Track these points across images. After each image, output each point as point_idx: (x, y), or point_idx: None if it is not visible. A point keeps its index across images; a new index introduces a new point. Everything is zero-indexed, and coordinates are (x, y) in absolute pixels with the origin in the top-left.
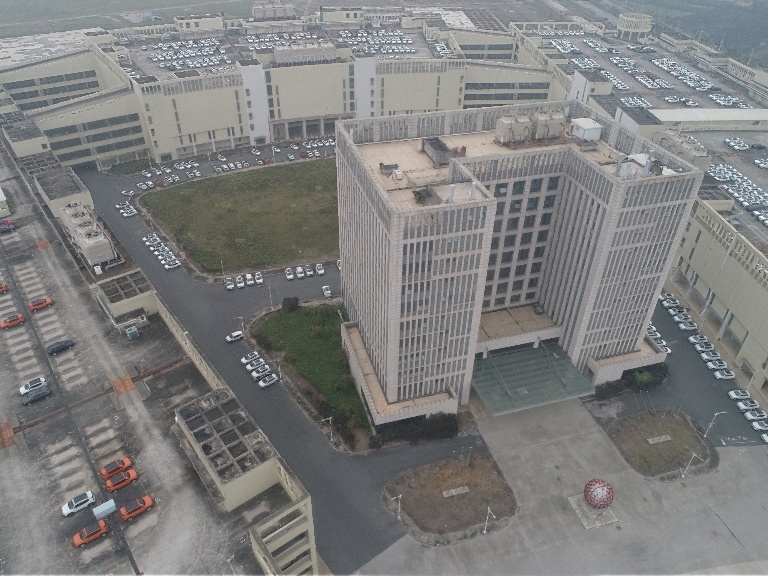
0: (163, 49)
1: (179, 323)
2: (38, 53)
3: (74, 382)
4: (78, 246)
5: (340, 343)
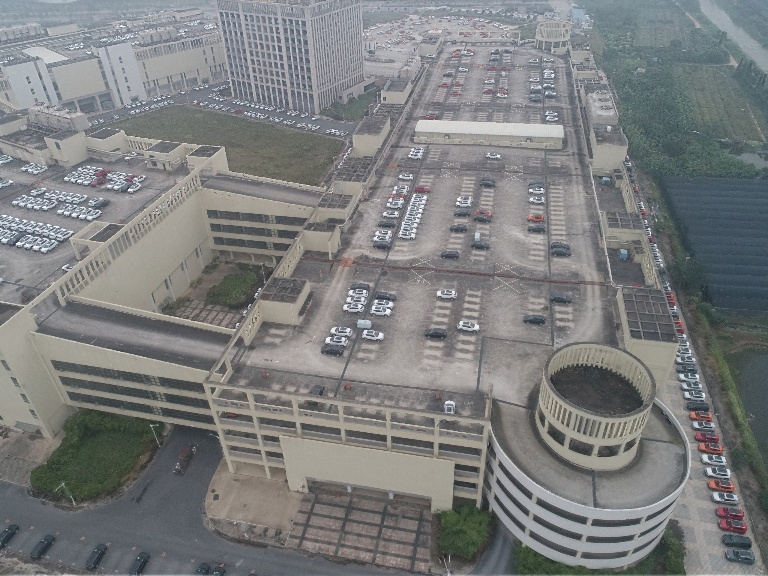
0: None
1: None
2: None
3: None
4: None
5: None
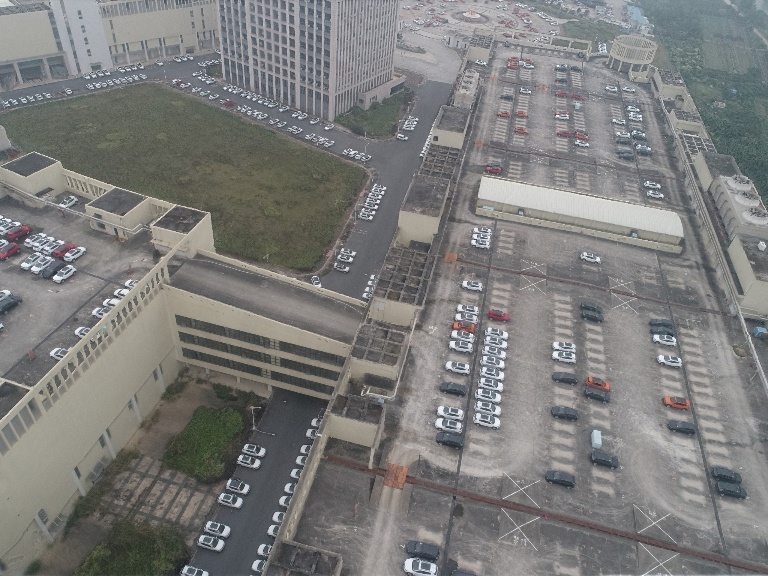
0: None
1: (463, 61)
2: None
3: (510, 89)
4: None
5: (365, 111)
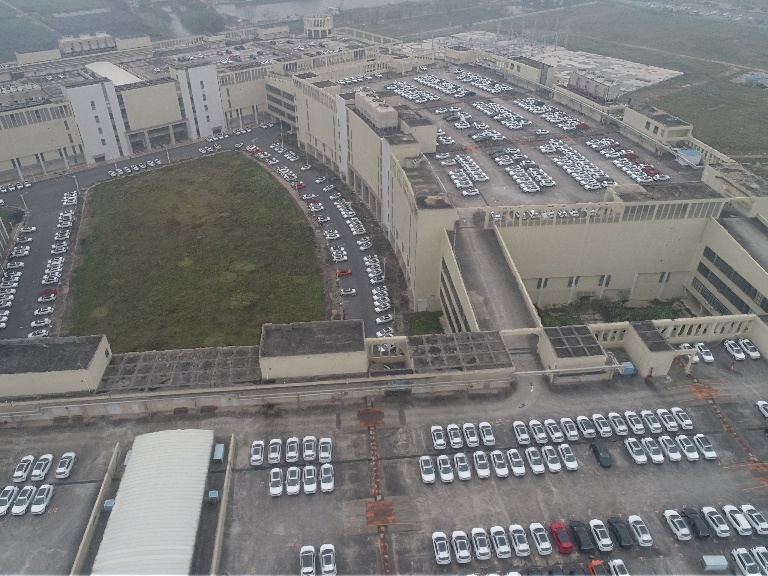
0: None
1: None
2: (564, 70)
3: None
4: None
5: None
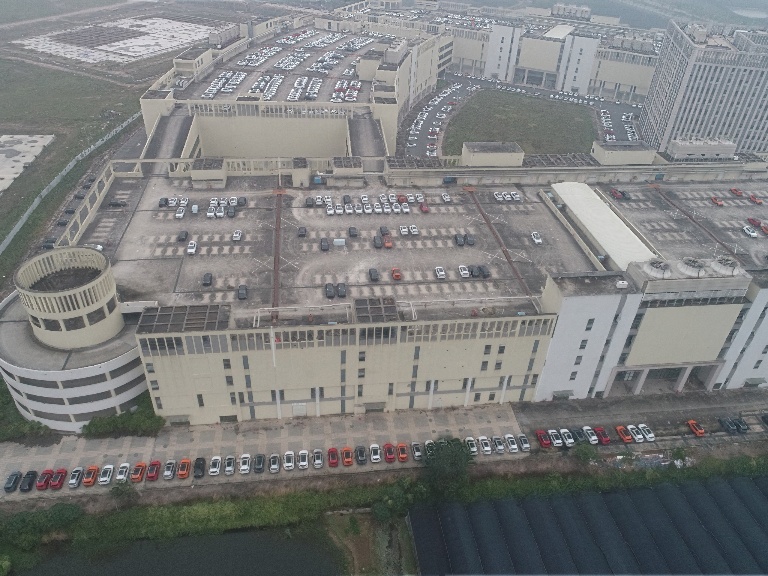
0: (230, 91)
1: None
2: None
3: None
4: (707, 158)
5: None
